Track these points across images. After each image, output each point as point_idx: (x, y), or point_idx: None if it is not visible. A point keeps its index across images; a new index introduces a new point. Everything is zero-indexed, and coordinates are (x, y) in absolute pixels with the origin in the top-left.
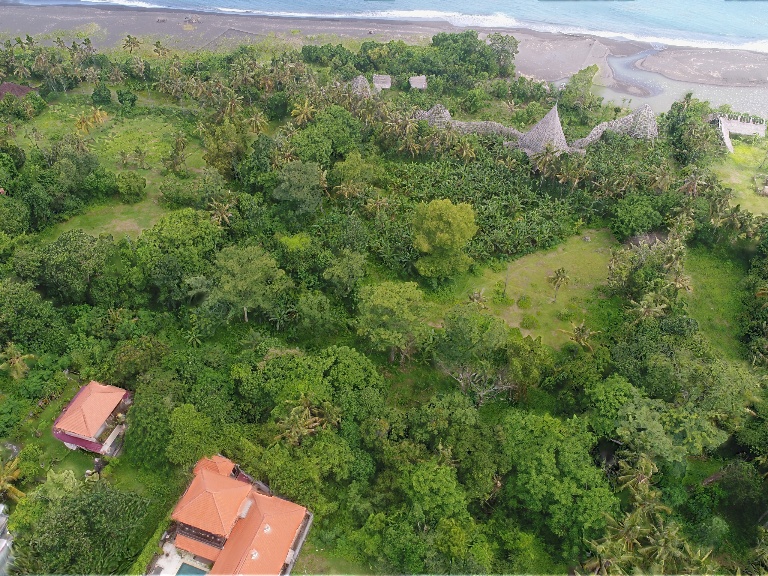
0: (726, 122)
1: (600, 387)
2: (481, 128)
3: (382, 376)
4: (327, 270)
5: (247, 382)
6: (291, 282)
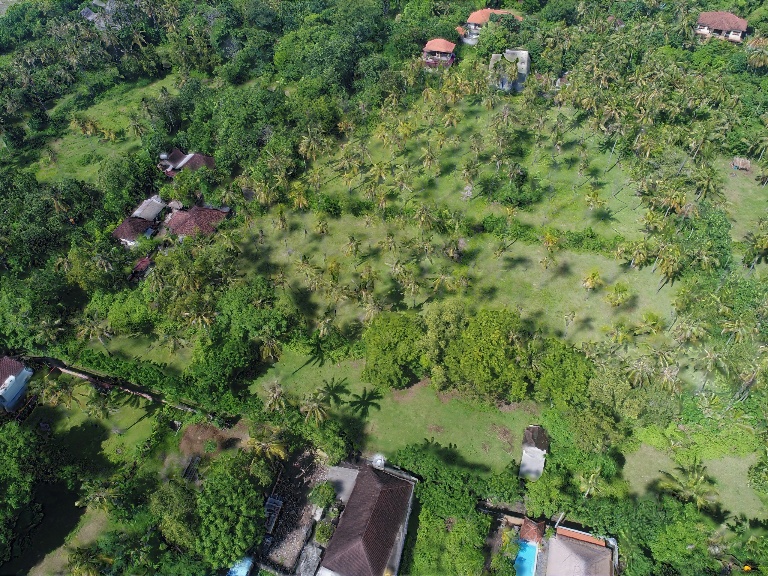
0: None
1: None
2: None
3: None
4: None
5: None
6: None
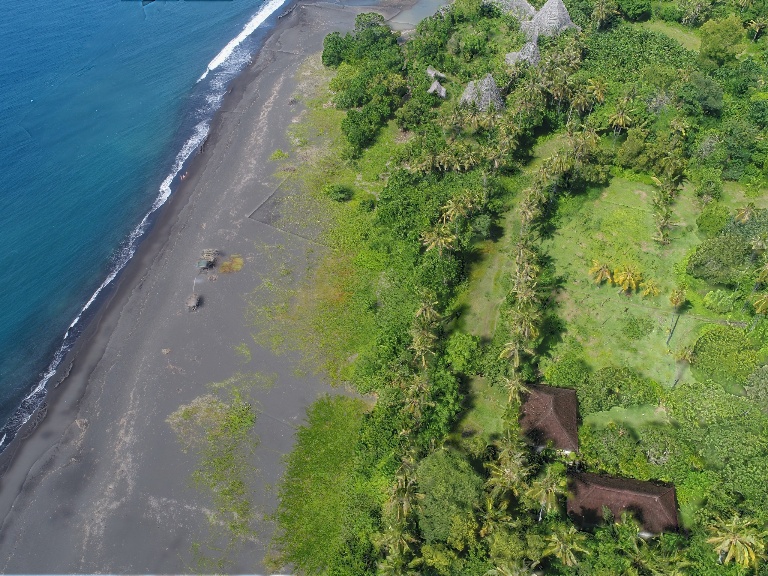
0: None
1: None
2: None
3: None
4: None
5: None
6: None
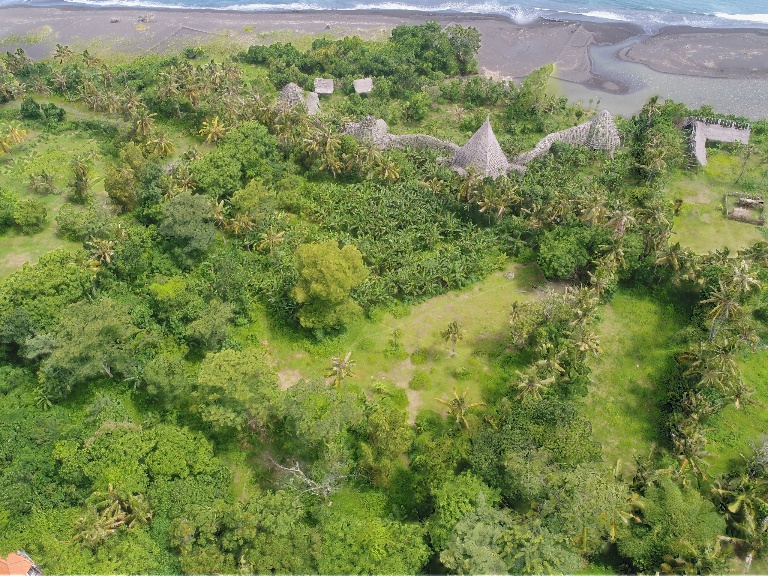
0: (703, 127)
1: (445, 488)
2: (414, 142)
3: (215, 459)
4: (191, 324)
5: (67, 464)
6: (156, 335)
